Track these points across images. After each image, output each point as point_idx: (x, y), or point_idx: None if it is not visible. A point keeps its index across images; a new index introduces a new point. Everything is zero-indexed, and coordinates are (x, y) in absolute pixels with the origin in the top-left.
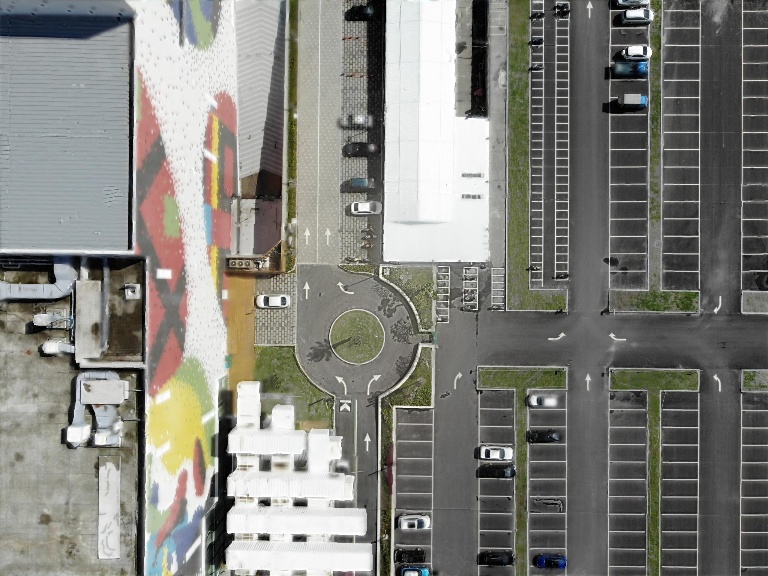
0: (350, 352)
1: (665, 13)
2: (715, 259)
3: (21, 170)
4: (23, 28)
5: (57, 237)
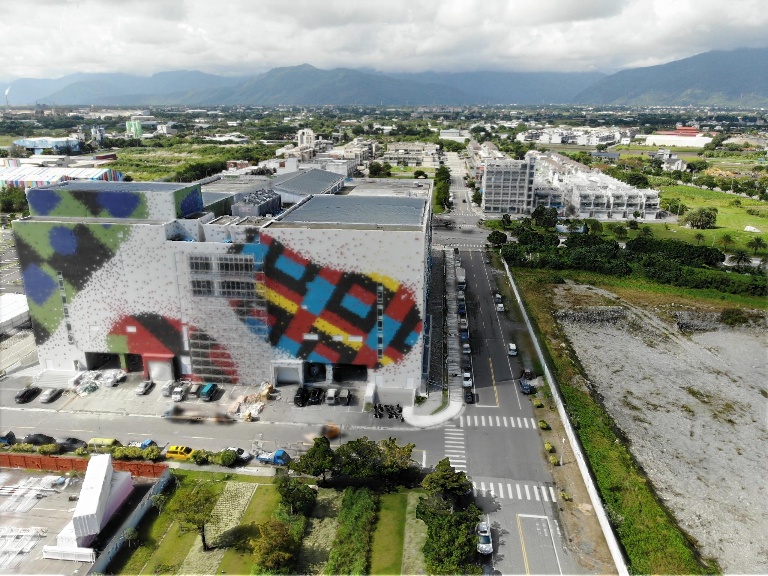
0: None
1: None
2: None
3: None
4: None
5: None
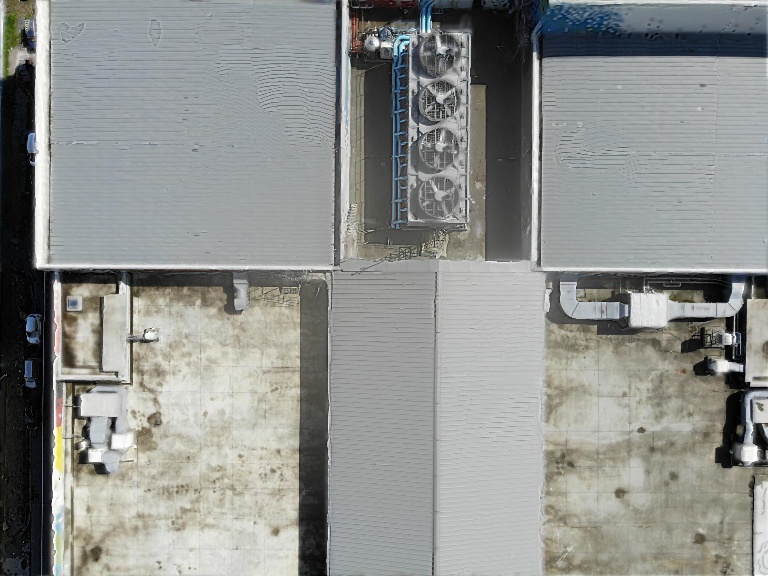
0: None
1: None
2: None
3: (725, 190)
4: (733, 48)
5: (760, 256)
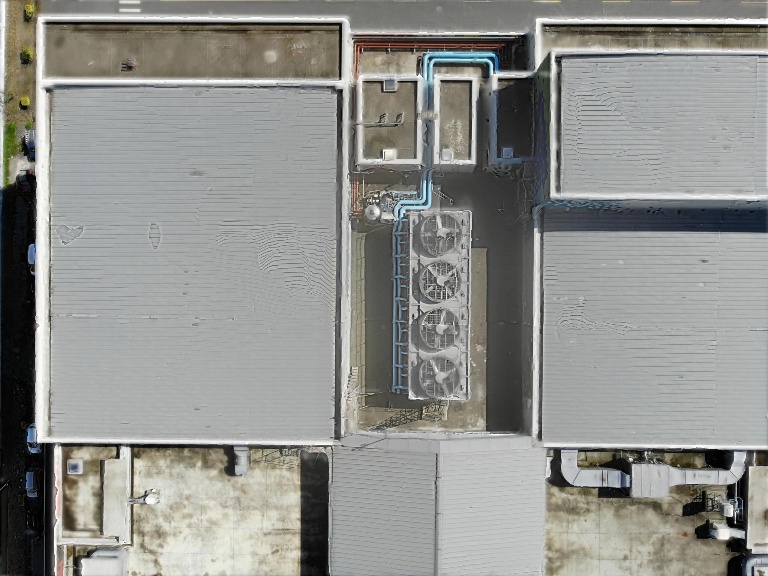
0: None
1: None
2: None
3: (727, 365)
4: (736, 224)
5: (763, 432)
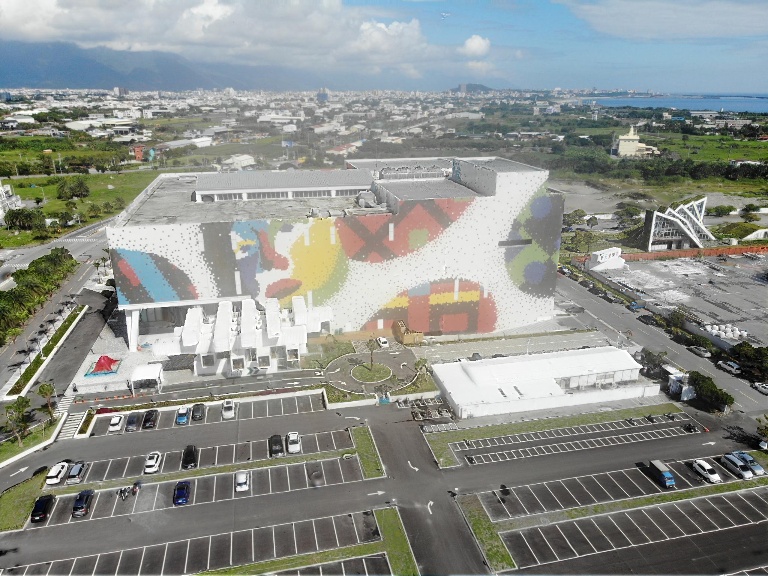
0: (360, 370)
1: (765, 488)
2: (564, 575)
3: None
4: (473, 188)
5: None
